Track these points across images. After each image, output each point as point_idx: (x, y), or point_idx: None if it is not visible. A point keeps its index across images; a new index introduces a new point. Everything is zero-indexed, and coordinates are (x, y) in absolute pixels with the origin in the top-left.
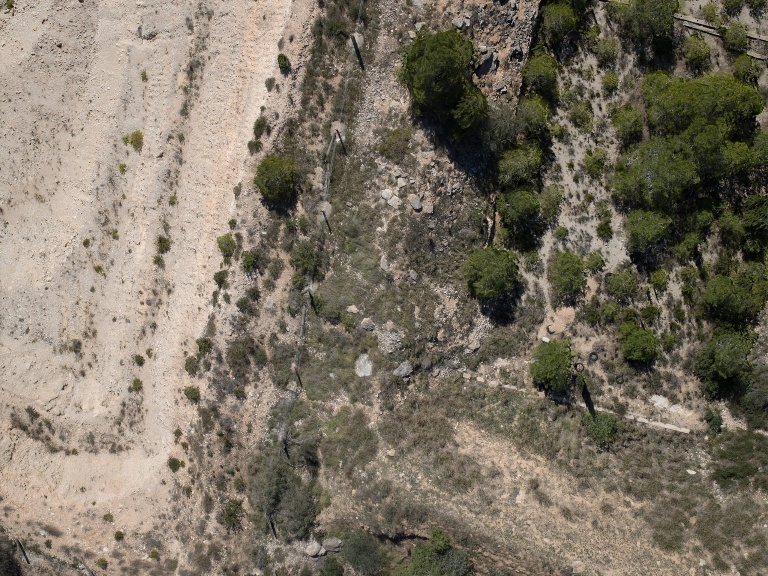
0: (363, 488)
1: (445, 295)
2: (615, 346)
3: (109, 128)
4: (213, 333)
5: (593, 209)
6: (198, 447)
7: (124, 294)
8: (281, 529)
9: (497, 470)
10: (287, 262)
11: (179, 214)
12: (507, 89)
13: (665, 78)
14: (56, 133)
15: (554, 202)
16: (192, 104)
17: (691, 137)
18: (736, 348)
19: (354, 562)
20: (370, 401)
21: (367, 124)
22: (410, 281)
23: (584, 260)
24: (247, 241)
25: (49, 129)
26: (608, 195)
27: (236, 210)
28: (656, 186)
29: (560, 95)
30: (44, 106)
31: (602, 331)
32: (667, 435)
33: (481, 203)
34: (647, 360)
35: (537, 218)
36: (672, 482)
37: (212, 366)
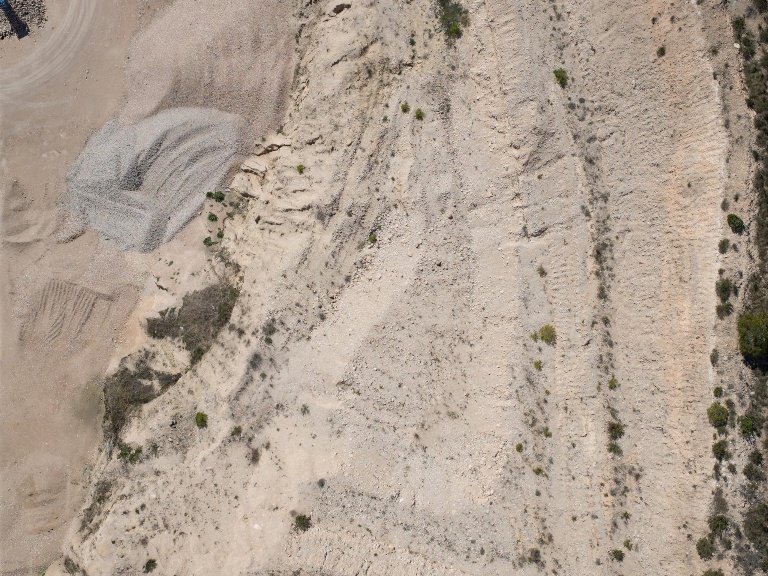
0: None
1: None
2: None
3: (514, 330)
4: (725, 508)
5: None
6: None
7: (580, 490)
8: None
9: None
10: None
11: (624, 396)
12: None
13: None
14: (454, 348)
15: None
16: (609, 286)
17: None
18: None
19: None
20: None
21: None
22: None
23: None
24: (739, 405)
25: (446, 346)
26: None
27: (718, 377)
28: None
29: None
30: (437, 325)
31: None
32: None
33: None
34: None
35: None
36: None
37: (732, 543)
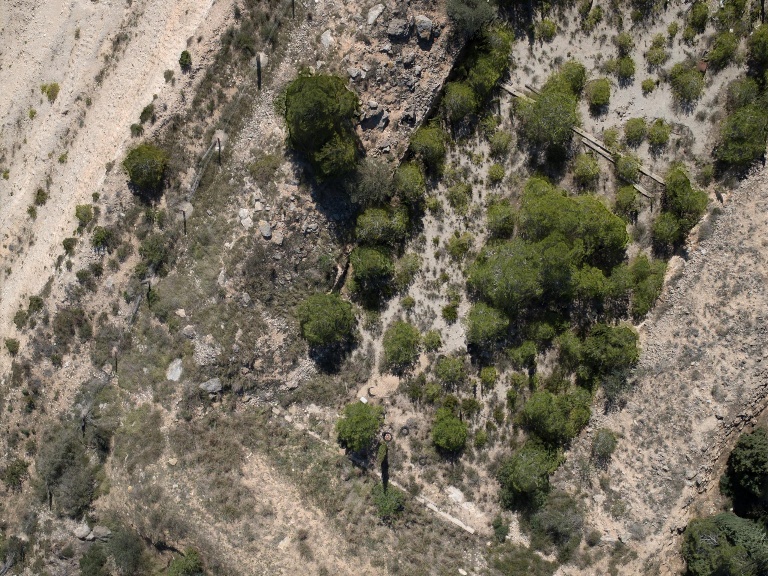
0: (138, 487)
1: (274, 327)
2: (428, 427)
3: (32, 73)
4: (47, 294)
5: (445, 289)
6: (2, 399)
7: None
8: (56, 502)
9: (271, 510)
10: (137, 249)
11: (64, 173)
12: (391, 149)
13: (543, 185)
14: None
15: (408, 271)
16: (108, 73)
17: (544, 248)
18: (533, 465)
19: (118, 556)
20: (169, 406)
21: (247, 142)
22: (241, 303)
23: (422, 335)
24: (104, 217)
25: None
26: (463, 280)
27: (103, 185)
28: (501, 285)
29: (445, 171)
30: None
31: (420, 409)
32: (451, 529)
33: (335, 250)
34: (454, 450)
35: (390, 281)
36: (440, 575)
37: (37, 326)
